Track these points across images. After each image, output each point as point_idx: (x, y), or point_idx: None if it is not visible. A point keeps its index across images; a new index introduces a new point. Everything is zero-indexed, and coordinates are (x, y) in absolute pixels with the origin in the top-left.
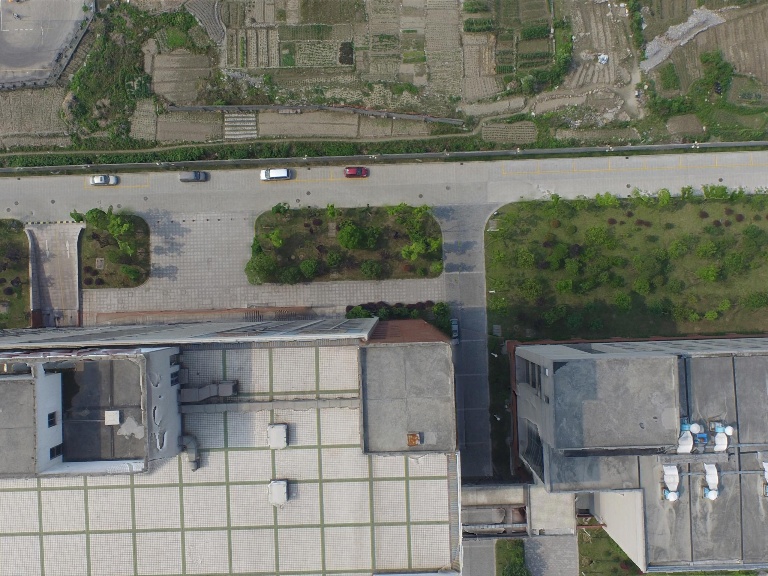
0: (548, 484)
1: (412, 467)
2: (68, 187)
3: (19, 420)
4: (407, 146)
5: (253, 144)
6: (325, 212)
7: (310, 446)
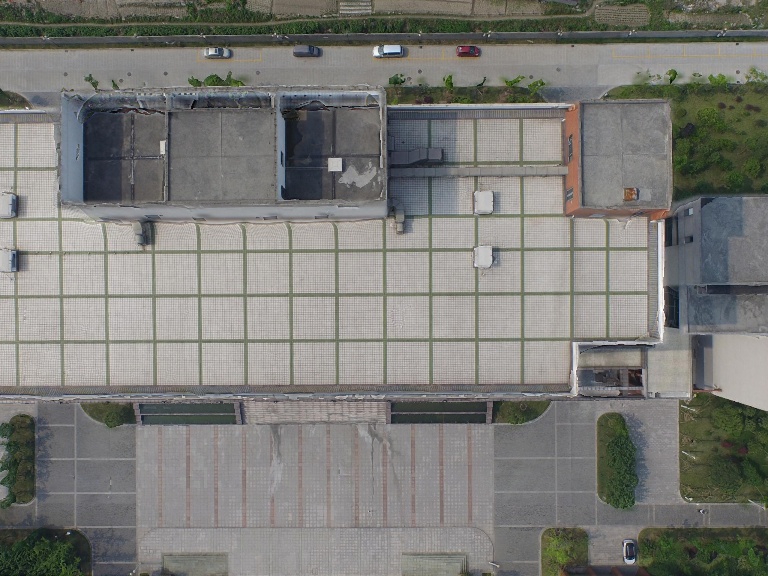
0: (686, 325)
1: (613, 238)
2: (181, 59)
3: (259, 148)
4: (521, 25)
5: (368, 19)
6: (436, 90)
7: (513, 215)
